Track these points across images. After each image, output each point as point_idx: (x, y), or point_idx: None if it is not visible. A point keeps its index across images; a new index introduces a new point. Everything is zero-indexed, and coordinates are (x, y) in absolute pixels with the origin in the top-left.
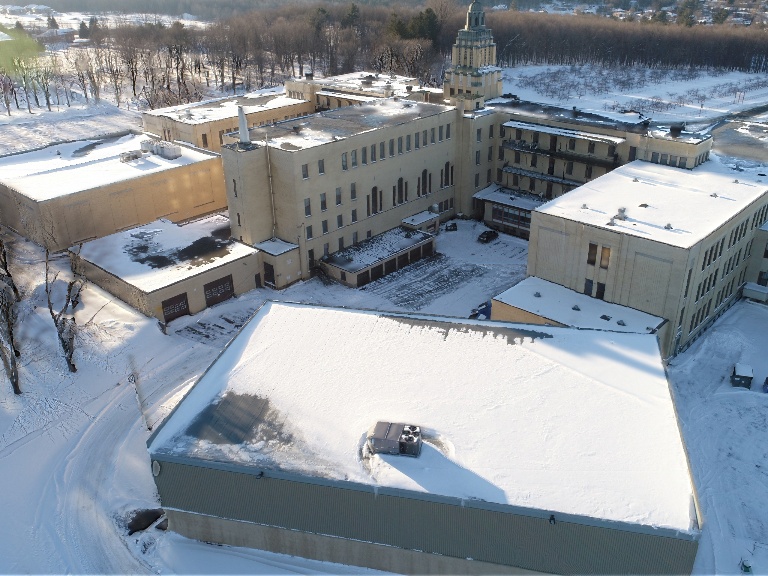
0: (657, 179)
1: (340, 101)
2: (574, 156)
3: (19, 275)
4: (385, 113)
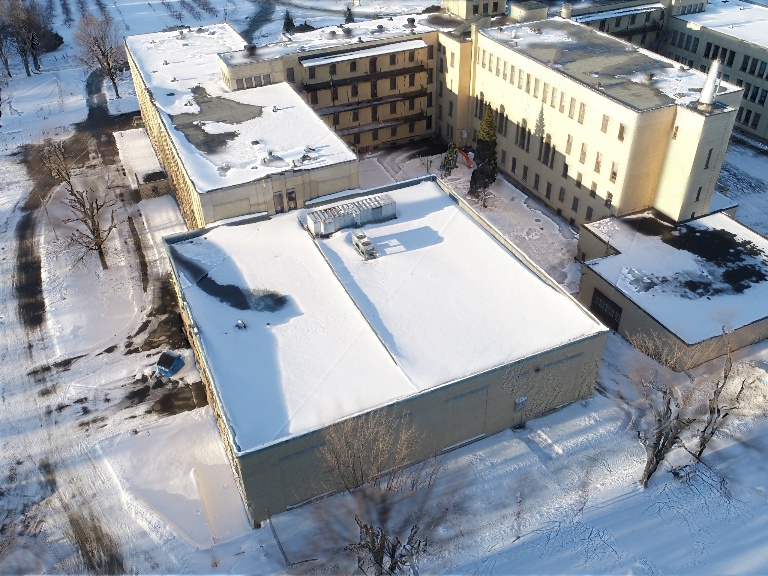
0: (730, 22)
1: (335, 66)
2: (634, 30)
3: (695, 424)
4: (561, 42)
